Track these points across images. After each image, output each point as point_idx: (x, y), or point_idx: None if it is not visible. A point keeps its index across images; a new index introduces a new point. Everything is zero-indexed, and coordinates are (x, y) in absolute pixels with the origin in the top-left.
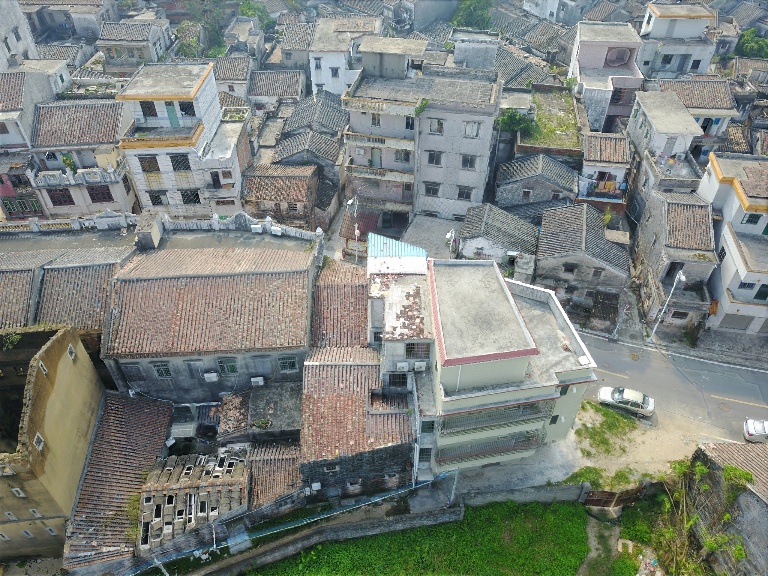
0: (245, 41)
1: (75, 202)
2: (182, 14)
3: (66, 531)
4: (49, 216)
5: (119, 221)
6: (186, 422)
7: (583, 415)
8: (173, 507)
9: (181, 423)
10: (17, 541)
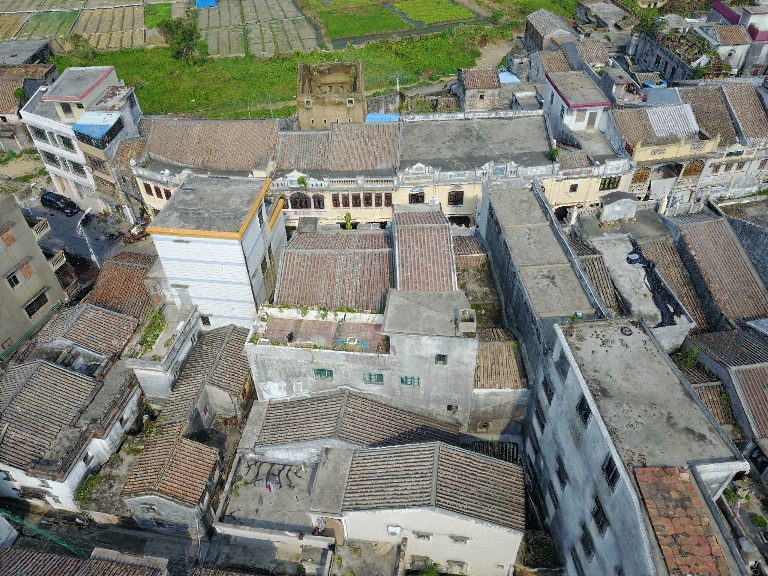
0: None
1: None
2: None
3: None
4: None
5: None
6: None
7: (39, 181)
8: None
9: None
10: None
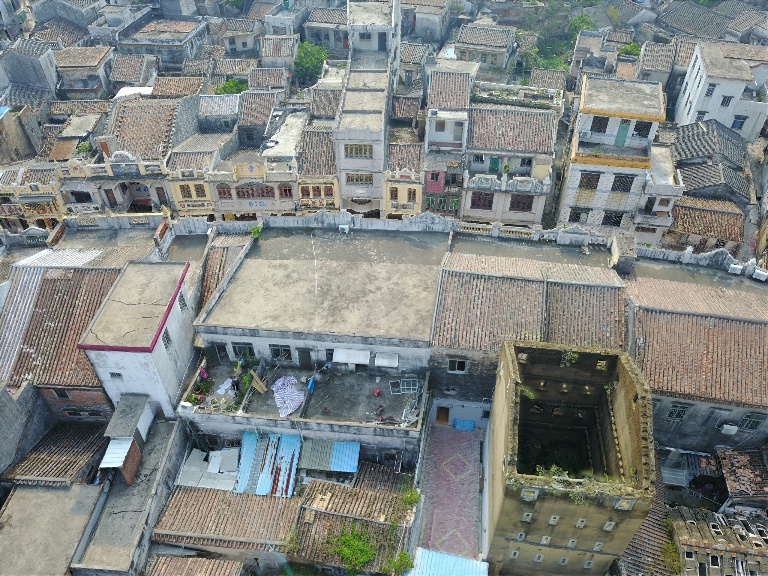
0: (599, 56)
1: (493, 207)
2: (513, 22)
3: (621, 572)
4: (461, 217)
5: (584, 239)
6: (676, 469)
7: None
8: (720, 570)
9: (671, 469)
10: (545, 564)
